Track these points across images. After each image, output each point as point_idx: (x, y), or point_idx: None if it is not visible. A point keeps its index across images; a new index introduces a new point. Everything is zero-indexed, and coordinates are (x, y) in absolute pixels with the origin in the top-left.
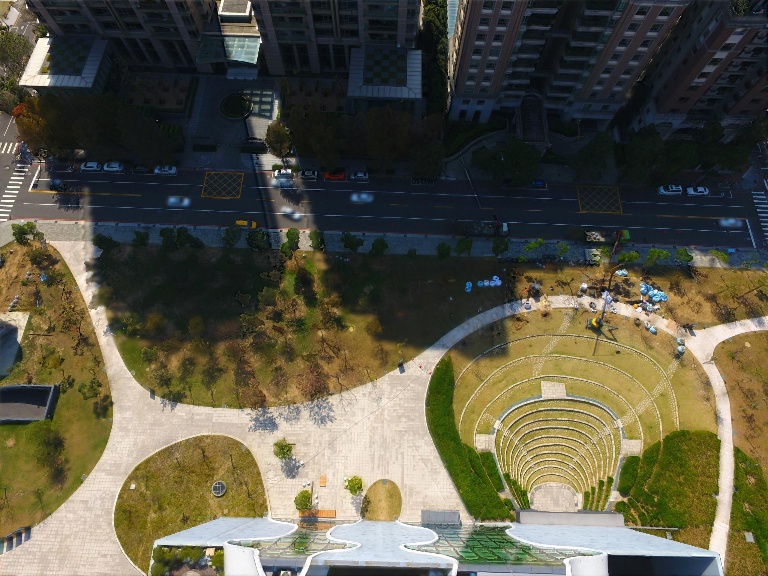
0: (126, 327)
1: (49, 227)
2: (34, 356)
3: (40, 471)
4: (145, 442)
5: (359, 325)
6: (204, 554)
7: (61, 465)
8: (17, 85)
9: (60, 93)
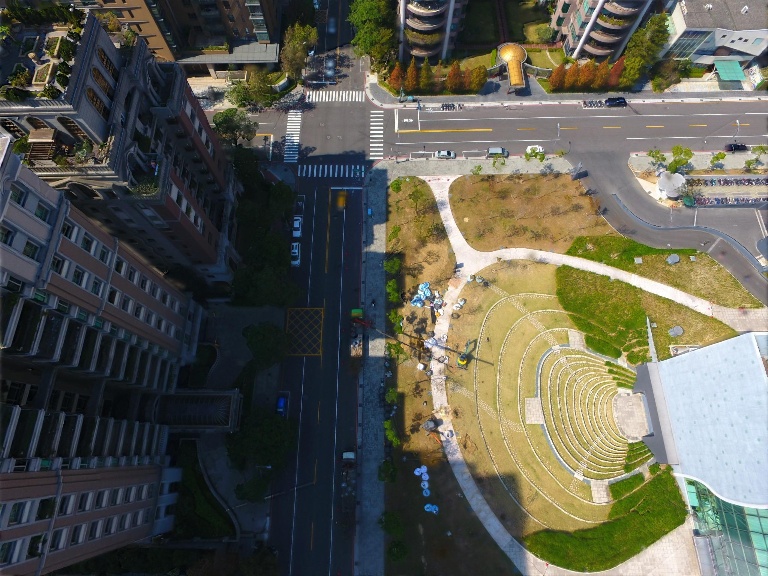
0: None
1: None
2: None
3: None
4: None
5: None
6: None
7: None
8: None
9: None
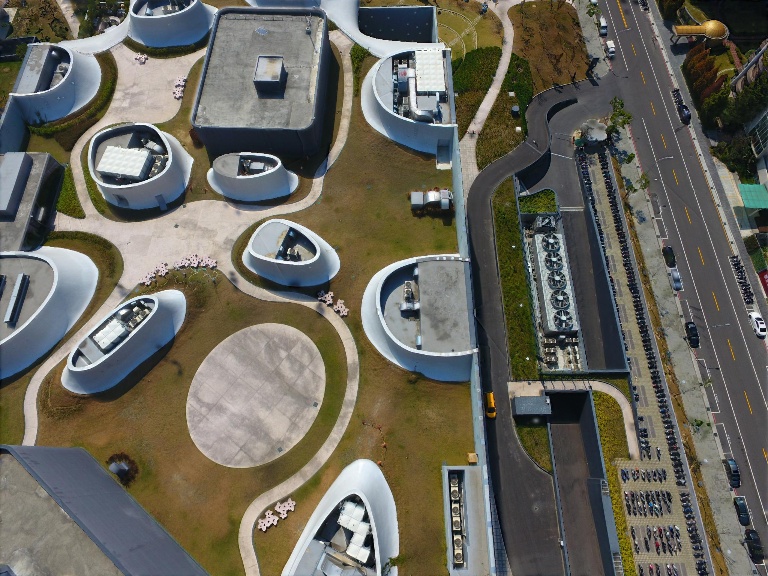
0: None
1: None
2: (21, 29)
3: None
4: None
5: None
6: (120, 7)
7: None
8: None
9: None
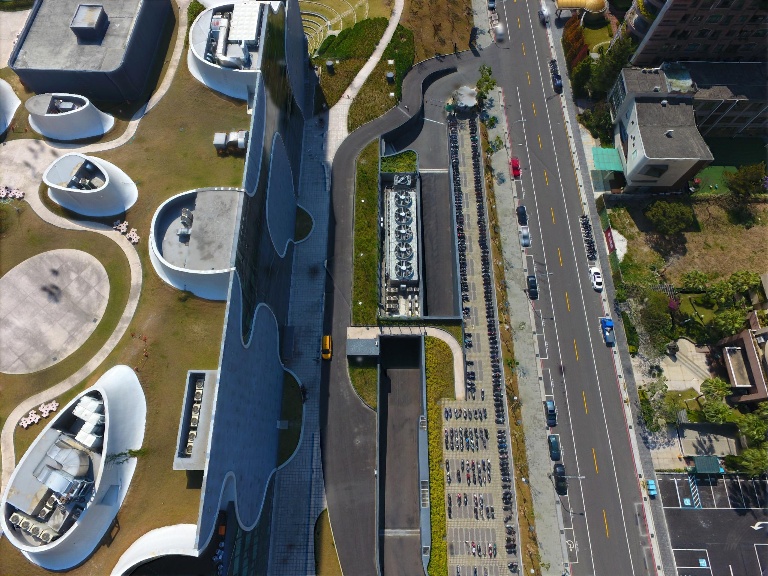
0: None
1: None
2: None
3: None
4: None
5: None
6: None
7: None
8: None
9: None
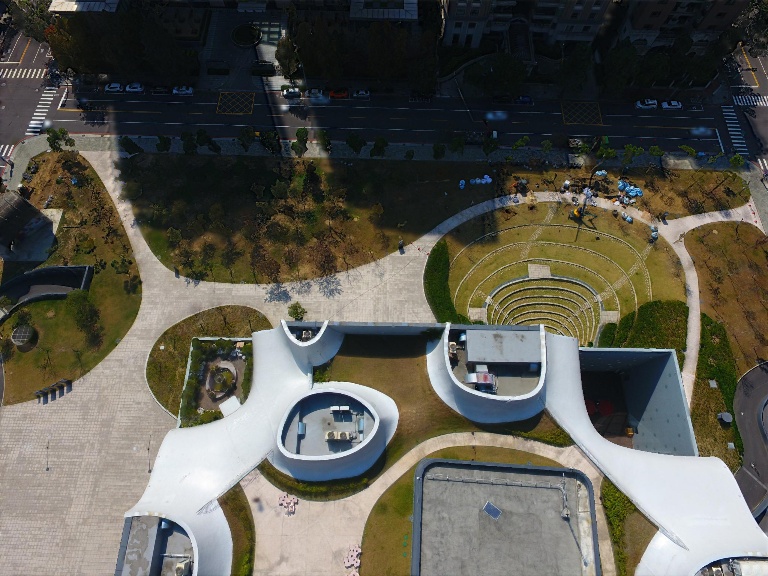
0: (151, 221)
1: (77, 140)
2: (69, 245)
3: (78, 336)
4: (172, 312)
5: (363, 216)
6: (235, 347)
7: (97, 331)
8: (46, 12)
9: (89, 11)
